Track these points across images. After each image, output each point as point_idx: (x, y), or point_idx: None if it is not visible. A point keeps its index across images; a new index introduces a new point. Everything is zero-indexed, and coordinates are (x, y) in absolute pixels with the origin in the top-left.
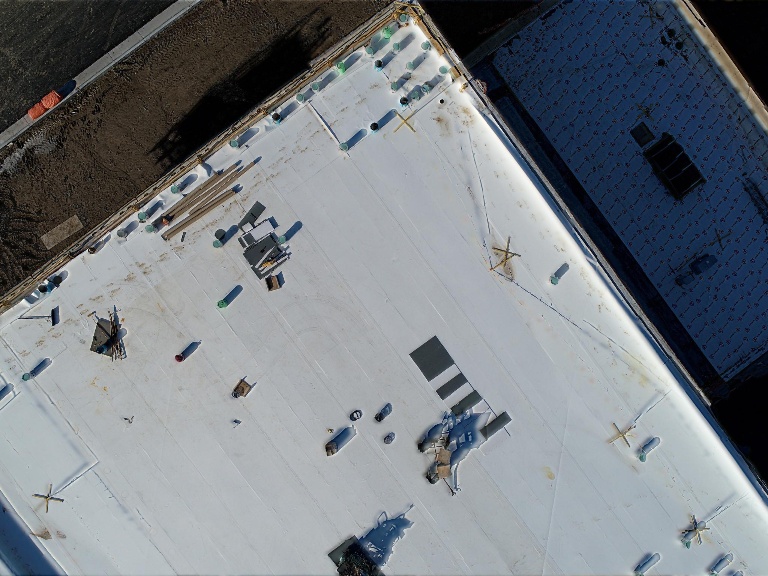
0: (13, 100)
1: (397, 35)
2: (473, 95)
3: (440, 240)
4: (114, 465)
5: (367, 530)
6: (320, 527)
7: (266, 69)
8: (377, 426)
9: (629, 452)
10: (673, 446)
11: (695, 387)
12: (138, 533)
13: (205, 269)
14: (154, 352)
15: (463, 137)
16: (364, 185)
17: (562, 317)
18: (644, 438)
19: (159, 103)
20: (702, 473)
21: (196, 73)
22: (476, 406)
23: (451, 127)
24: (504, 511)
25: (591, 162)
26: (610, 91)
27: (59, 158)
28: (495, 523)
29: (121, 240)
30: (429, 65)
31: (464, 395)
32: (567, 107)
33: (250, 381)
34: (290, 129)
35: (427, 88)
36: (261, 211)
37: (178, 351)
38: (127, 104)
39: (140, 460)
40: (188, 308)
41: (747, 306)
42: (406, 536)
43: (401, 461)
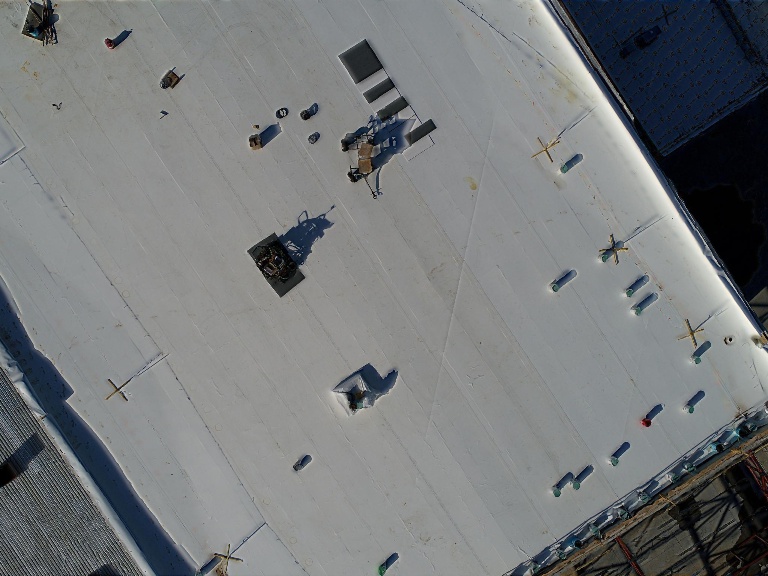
0: None
1: None
2: None
3: None
4: (40, 151)
5: (287, 228)
6: (241, 223)
7: None
8: (302, 125)
9: (551, 167)
10: (595, 163)
11: (619, 100)
12: (61, 221)
13: None
14: (85, 39)
15: None
16: None
17: (492, 28)
18: (567, 154)
19: None
20: (623, 192)
21: None
22: (402, 112)
23: None
24: (424, 218)
25: None
26: None
27: None
28: (414, 229)
29: None
30: None
31: (390, 100)
32: None
33: (179, 73)
34: None
35: None
36: None
37: (109, 38)
38: None
39: (66, 147)
40: None
41: (690, 84)
42: (326, 236)
43: (324, 162)
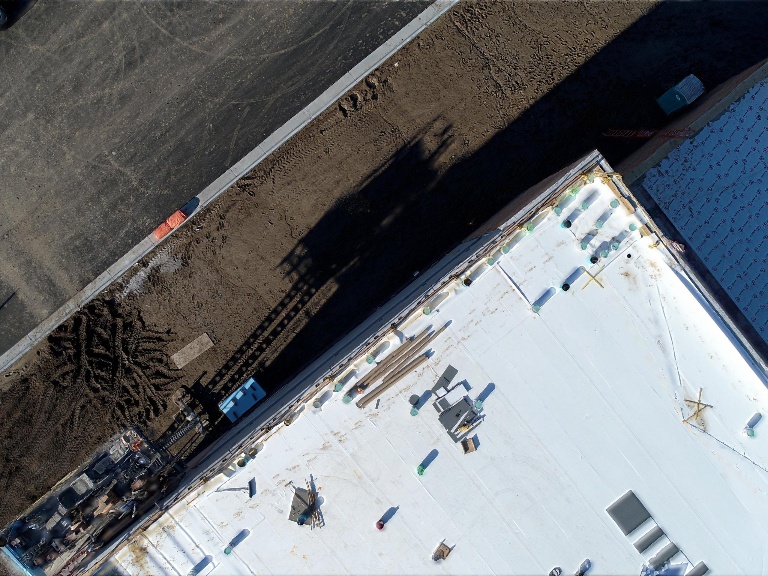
0: (136, 220)
1: (583, 192)
2: (665, 252)
3: (632, 395)
4: None
5: None
6: None
7: (390, 179)
8: None
9: None
10: None
11: None
12: None
13: (400, 435)
14: (352, 519)
15: (651, 291)
16: (555, 343)
17: (756, 466)
18: None
19: (283, 217)
20: None
21: (320, 186)
22: (673, 557)
23: (639, 281)
24: None
25: (743, 279)
26: (760, 207)
27: (185, 276)
28: None
29: (316, 410)
30: (616, 221)
31: (661, 547)
32: (718, 225)
33: (449, 543)
34: (479, 291)
35: (617, 246)
36: (454, 375)
37: (376, 517)
38: (251, 219)
39: None
40: (385, 474)
41: None
42: None
43: None
